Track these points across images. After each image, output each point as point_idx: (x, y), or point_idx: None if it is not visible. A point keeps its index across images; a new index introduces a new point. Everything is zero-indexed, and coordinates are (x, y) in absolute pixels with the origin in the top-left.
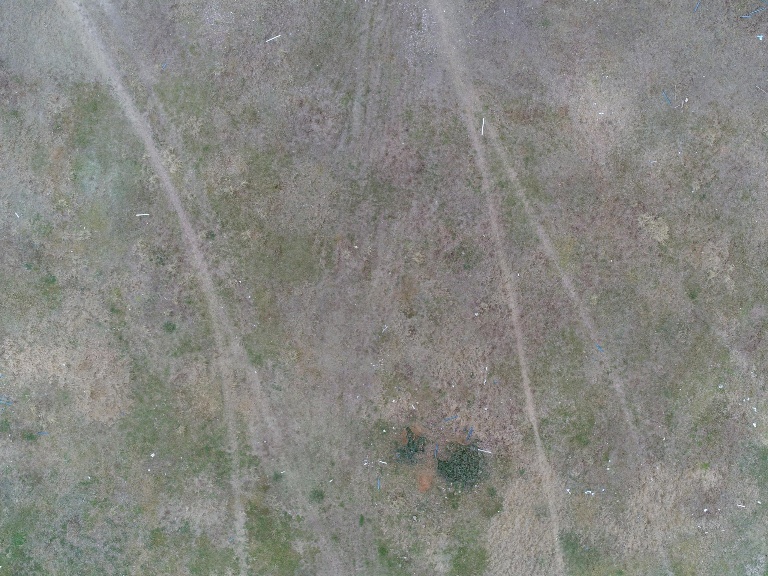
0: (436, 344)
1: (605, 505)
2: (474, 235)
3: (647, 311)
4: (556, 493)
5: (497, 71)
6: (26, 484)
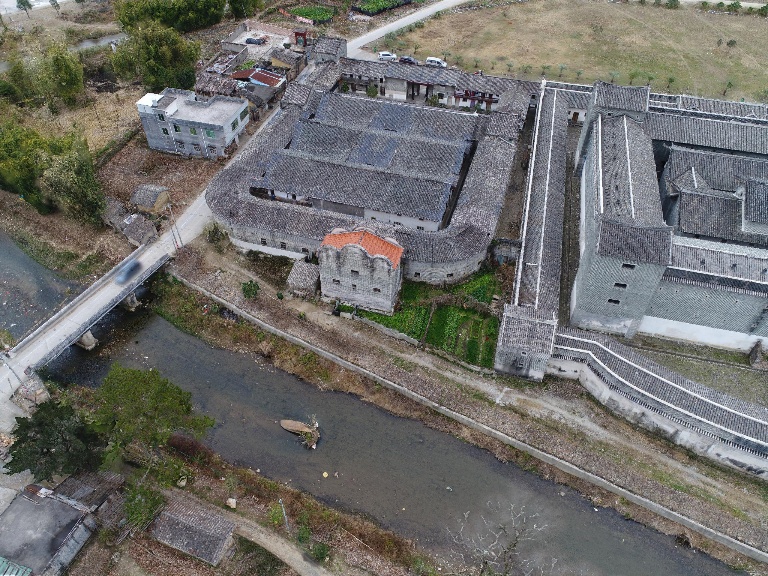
0: None
1: None
2: None
3: (761, 43)
4: None
5: None
6: None
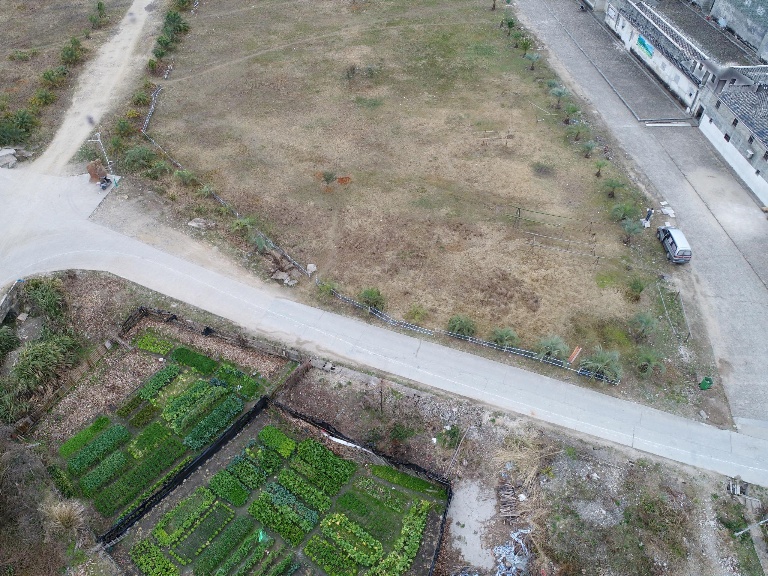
0: (324, 7)
1: None
2: (288, 5)
3: None
4: None
5: (236, 6)
6: (400, 59)
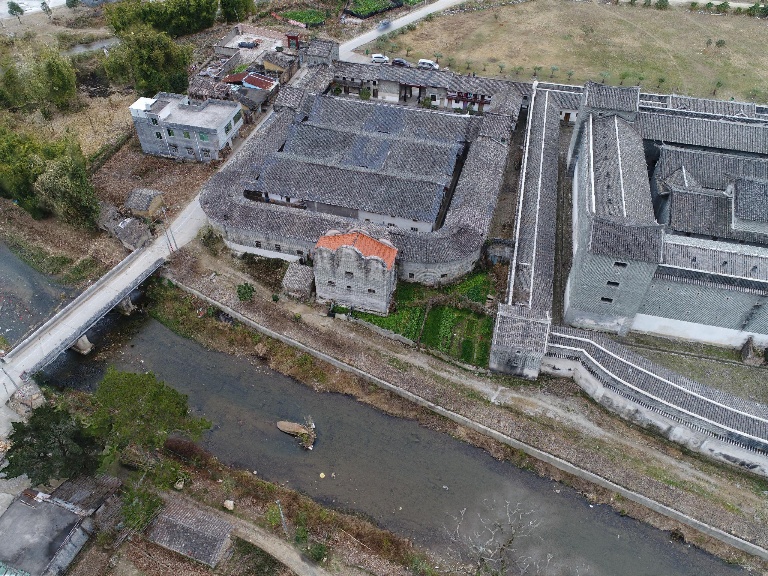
0: None
1: None
2: None
3: None
4: (743, 58)
5: None
6: None
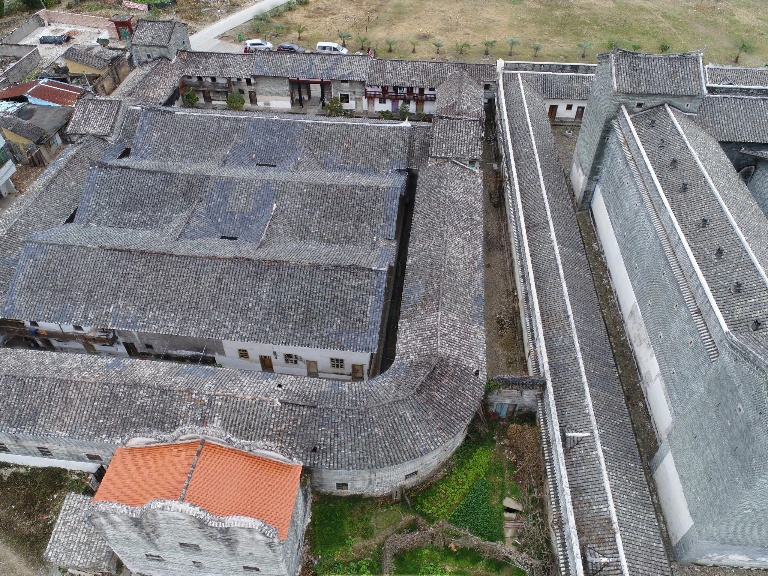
0: None
1: (765, 14)
2: None
3: None
4: None
5: None
6: None
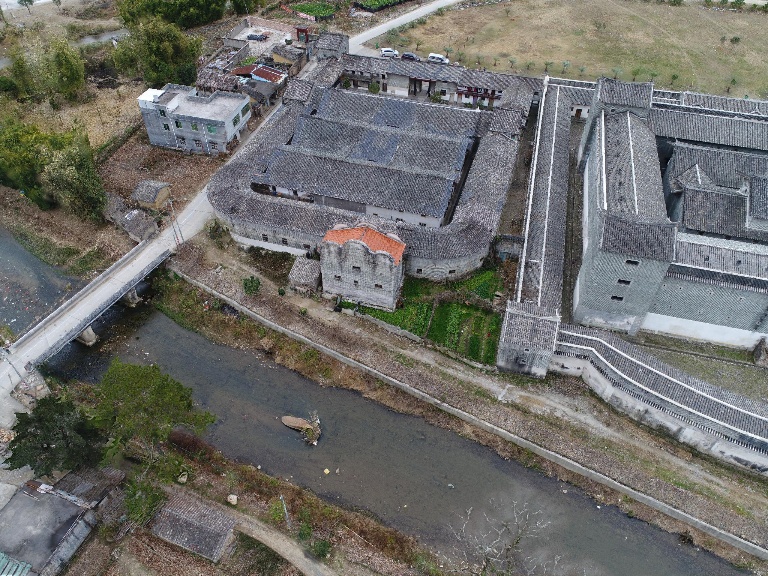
0: None
1: None
2: None
3: (765, 40)
4: None
5: None
6: None
